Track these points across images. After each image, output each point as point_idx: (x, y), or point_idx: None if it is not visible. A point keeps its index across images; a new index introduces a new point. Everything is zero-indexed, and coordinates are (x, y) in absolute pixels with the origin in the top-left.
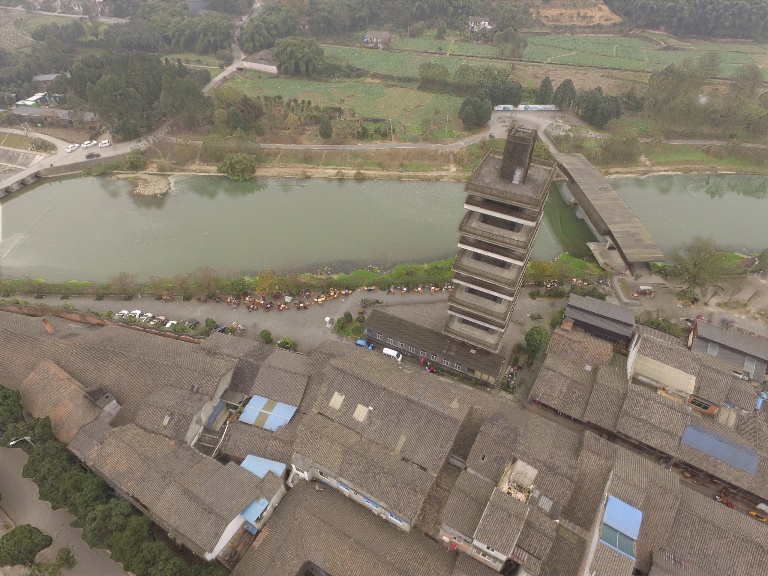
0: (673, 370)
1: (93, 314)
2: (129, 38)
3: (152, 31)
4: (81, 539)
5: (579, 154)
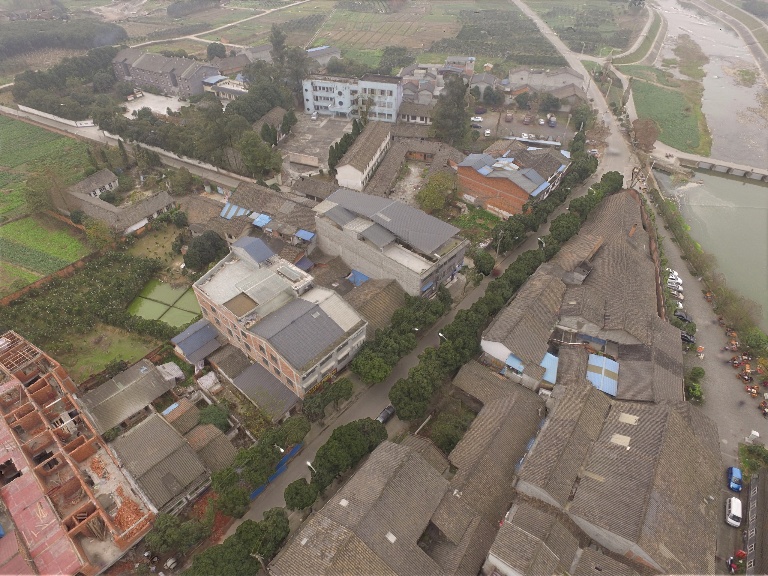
0: None
1: (660, 252)
2: None
3: None
4: None
5: None
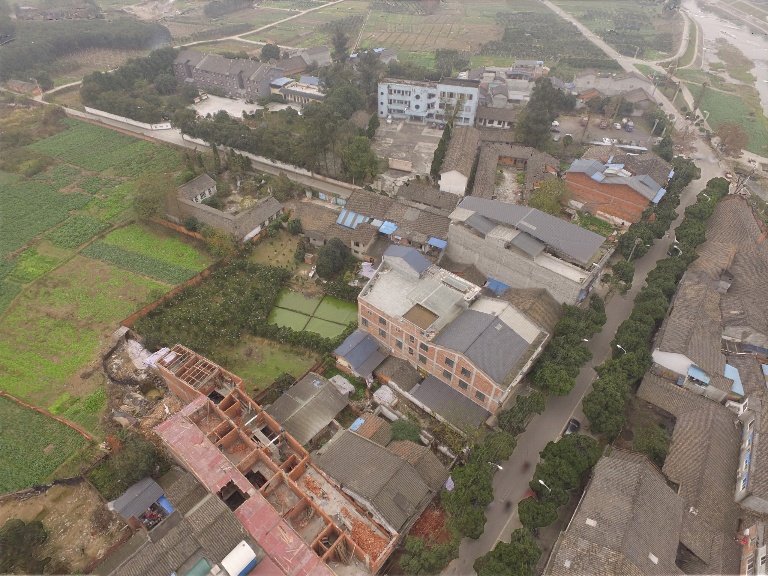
0: None
1: None
2: None
3: None
4: (631, 302)
5: None
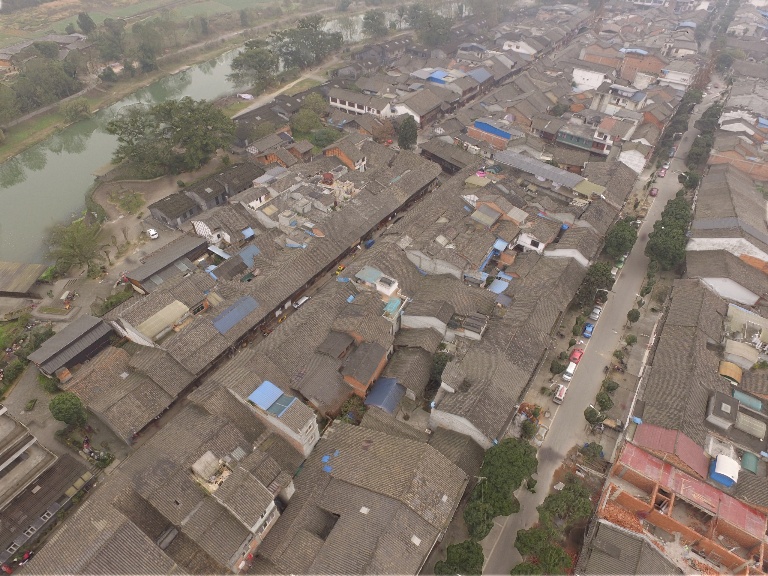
0: (164, 311)
1: None
2: None
3: None
4: None
5: None
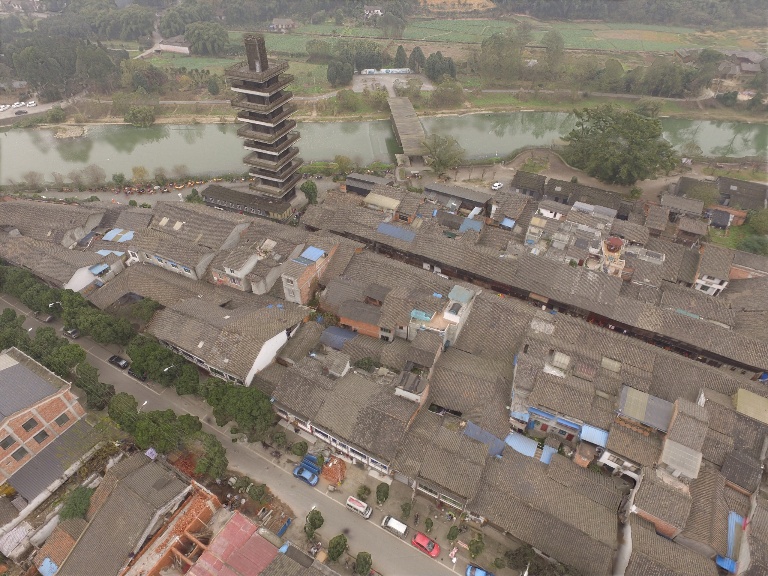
0: (388, 199)
1: (8, 194)
2: (60, 28)
3: (81, 22)
4: None
5: (405, 97)
